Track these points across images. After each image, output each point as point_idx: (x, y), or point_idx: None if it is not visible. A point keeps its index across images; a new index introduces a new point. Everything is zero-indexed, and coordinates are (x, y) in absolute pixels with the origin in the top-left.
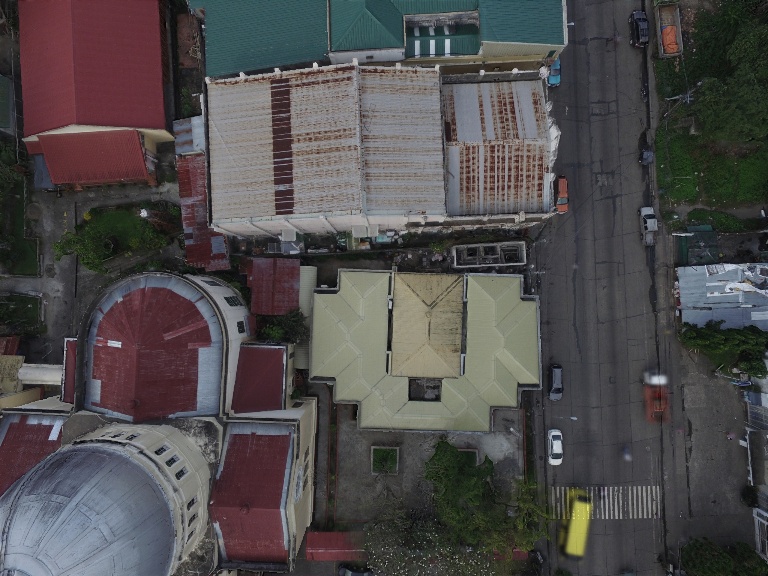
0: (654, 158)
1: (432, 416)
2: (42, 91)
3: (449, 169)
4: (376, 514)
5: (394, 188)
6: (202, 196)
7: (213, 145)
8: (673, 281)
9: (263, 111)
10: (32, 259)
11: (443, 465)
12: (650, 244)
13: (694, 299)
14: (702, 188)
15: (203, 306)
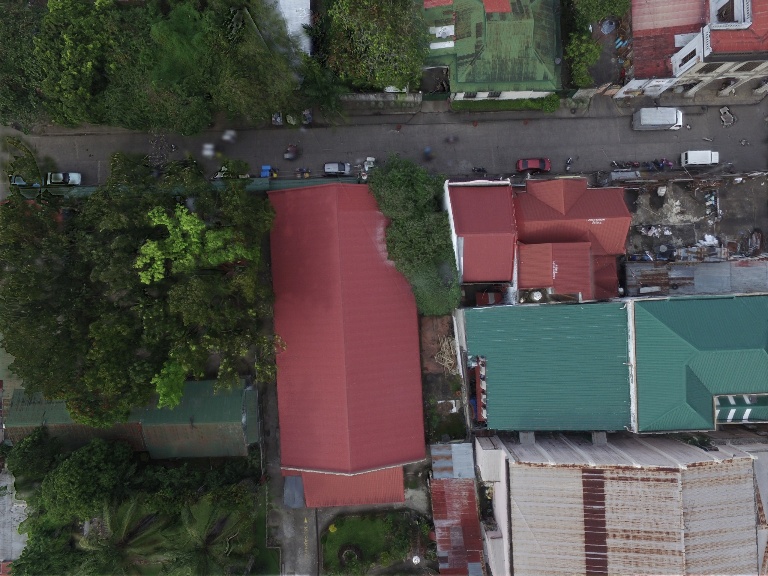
0: None
1: None
2: (305, 424)
3: None
4: None
5: None
6: (459, 520)
7: (516, 527)
8: None
9: (573, 500)
10: (274, 569)
11: None
12: None
13: None
14: None
15: None
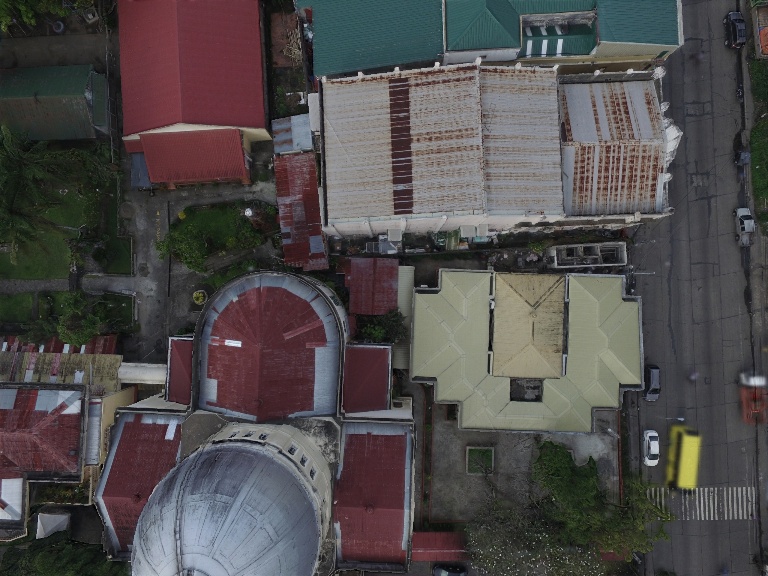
0: (749, 159)
1: (535, 416)
2: (144, 90)
3: (563, 169)
4: (471, 514)
5: (514, 188)
6: (300, 195)
7: (329, 144)
8: None
9: (381, 110)
10: (126, 258)
11: (554, 466)
12: (746, 245)
13: None
14: None
15: (318, 306)
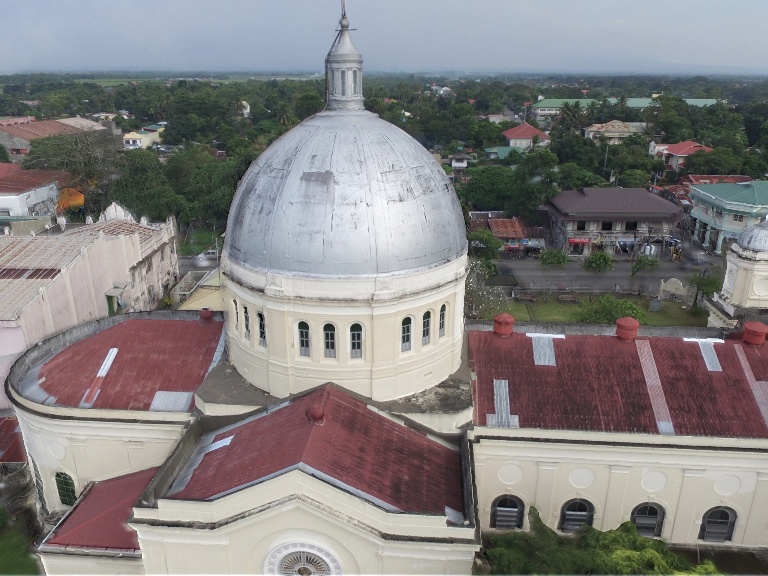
0: None
1: None
2: None
3: None
4: None
5: None
6: None
7: None
8: None
9: None
10: None
11: None
12: None
13: None
14: None
15: None
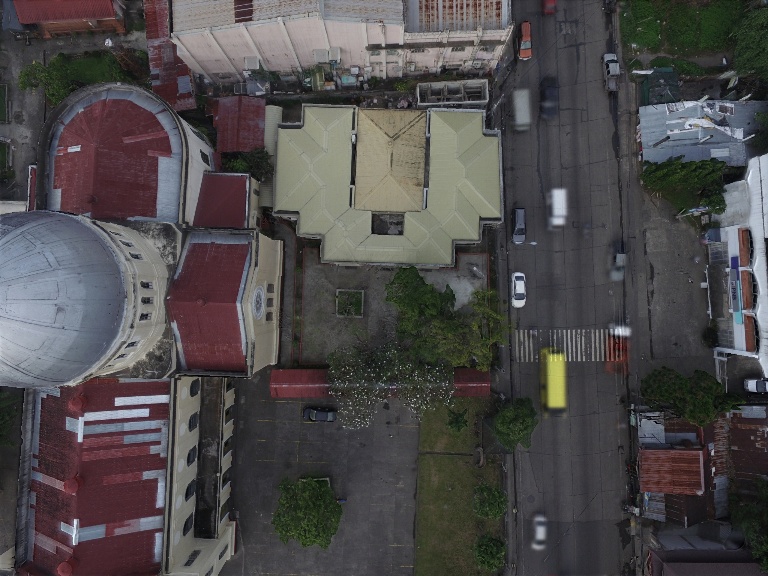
0: (617, 7)
1: (394, 248)
2: None
3: None
4: None
5: None
6: None
7: None
8: (635, 126)
9: None
10: (0, 105)
11: (402, 282)
12: (613, 89)
13: (654, 137)
14: (664, 36)
15: (164, 118)
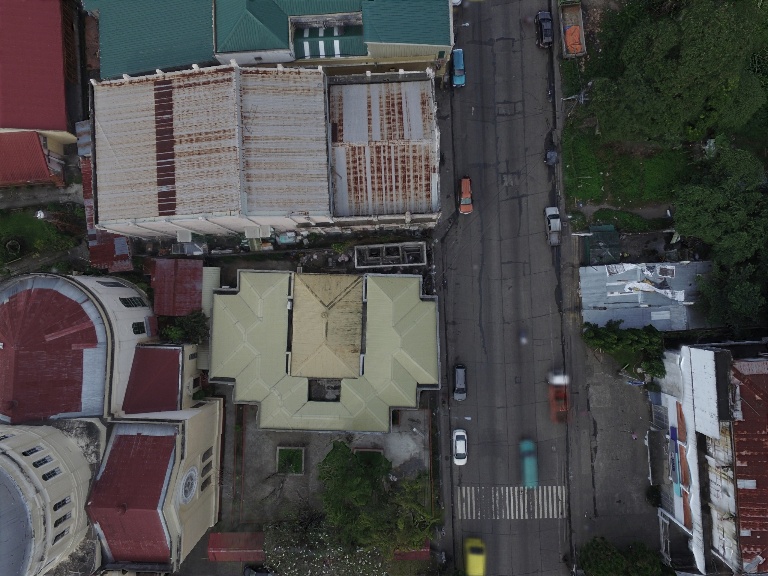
0: (560, 158)
1: (330, 416)
2: None
3: (336, 170)
4: (282, 514)
5: (276, 189)
6: None
7: (99, 146)
8: (578, 281)
9: (147, 112)
10: None
11: (333, 465)
12: (554, 244)
13: (595, 299)
14: (608, 188)
15: (90, 307)
